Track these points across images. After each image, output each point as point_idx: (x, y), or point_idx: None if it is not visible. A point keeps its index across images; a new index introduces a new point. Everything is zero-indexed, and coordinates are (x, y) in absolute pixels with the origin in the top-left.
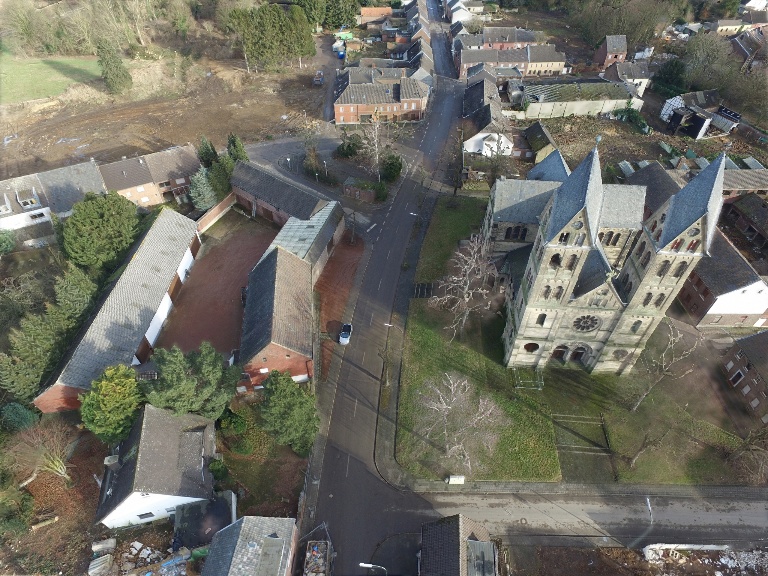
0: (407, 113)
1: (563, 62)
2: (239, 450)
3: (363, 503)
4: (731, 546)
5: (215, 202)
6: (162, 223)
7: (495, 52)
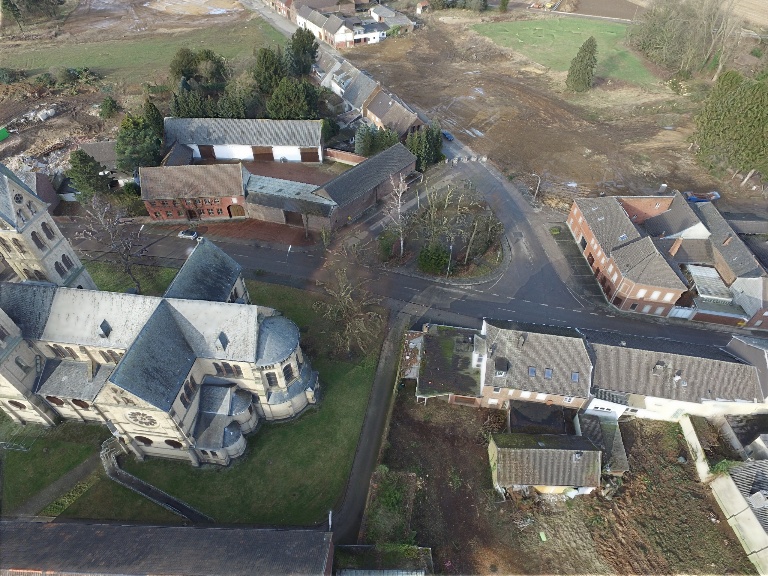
0: (607, 279)
1: None
2: None
3: None
4: None
5: (361, 153)
6: (304, 124)
7: None
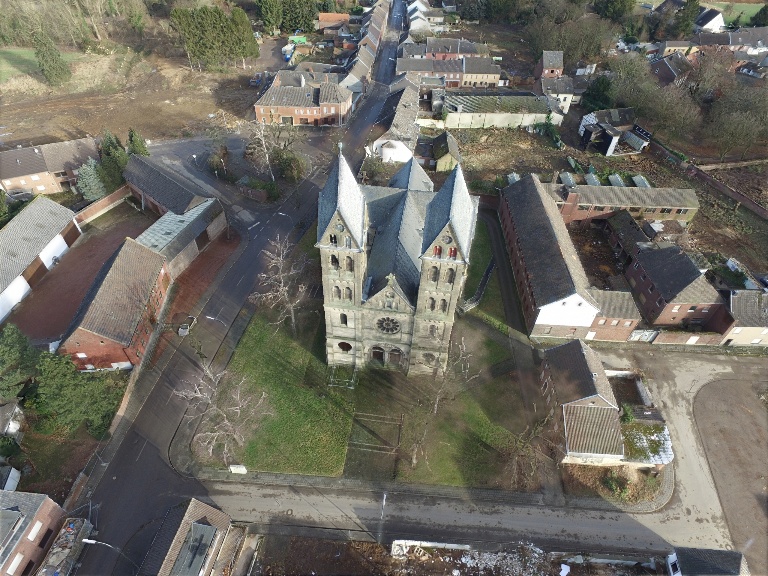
0: (327, 117)
1: (498, 75)
2: (38, 429)
3: (142, 486)
4: (480, 547)
5: (104, 193)
6: (32, 210)
7: (430, 62)
